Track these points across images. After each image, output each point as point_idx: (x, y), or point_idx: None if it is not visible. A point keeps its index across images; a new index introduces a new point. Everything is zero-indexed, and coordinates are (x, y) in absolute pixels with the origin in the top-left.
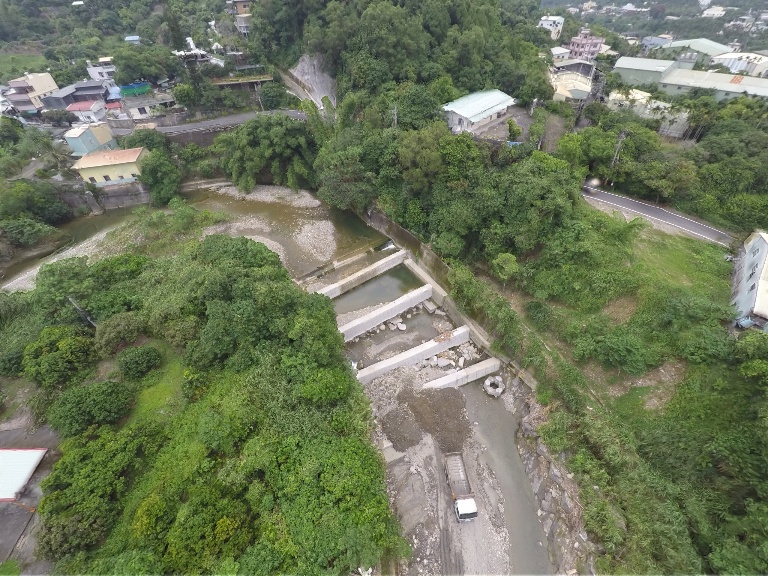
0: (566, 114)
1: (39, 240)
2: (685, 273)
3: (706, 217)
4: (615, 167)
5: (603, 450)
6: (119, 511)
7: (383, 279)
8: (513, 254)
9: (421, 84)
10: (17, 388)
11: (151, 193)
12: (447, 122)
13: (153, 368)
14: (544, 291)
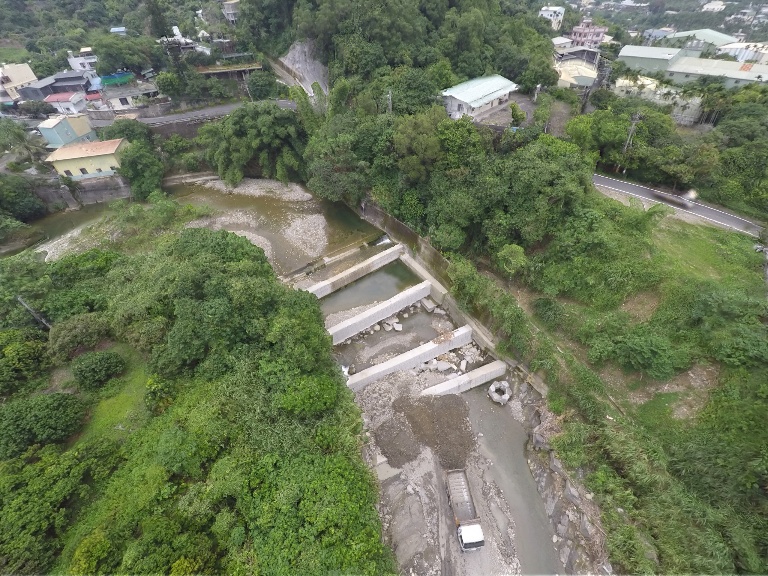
0: (572, 100)
1: (7, 237)
2: (711, 265)
3: (729, 205)
4: (628, 152)
5: (627, 467)
6: (56, 551)
7: (378, 276)
8: None
9: None
10: None
11: (132, 187)
12: (445, 108)
13: (114, 376)
14: (554, 286)
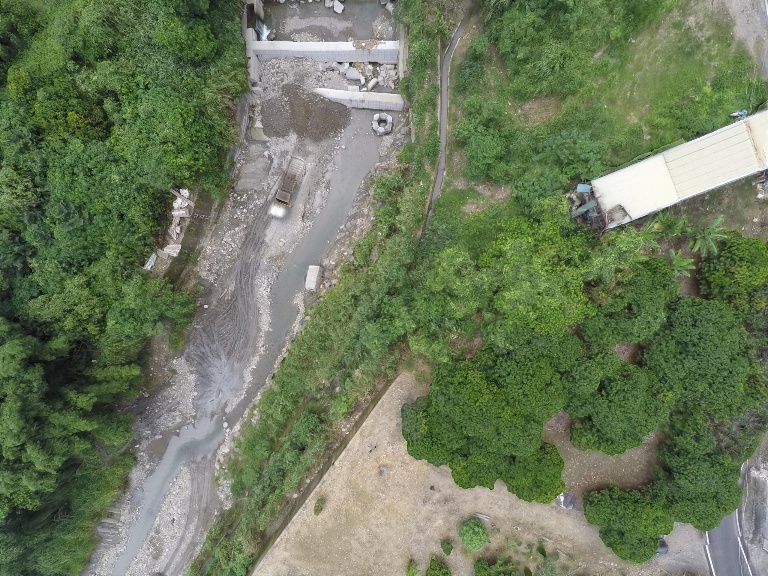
0: None
1: None
2: (652, 103)
3: None
4: None
5: None
6: (4, 70)
7: None
8: None
9: None
10: None
11: None
12: None
13: None
14: (486, 39)
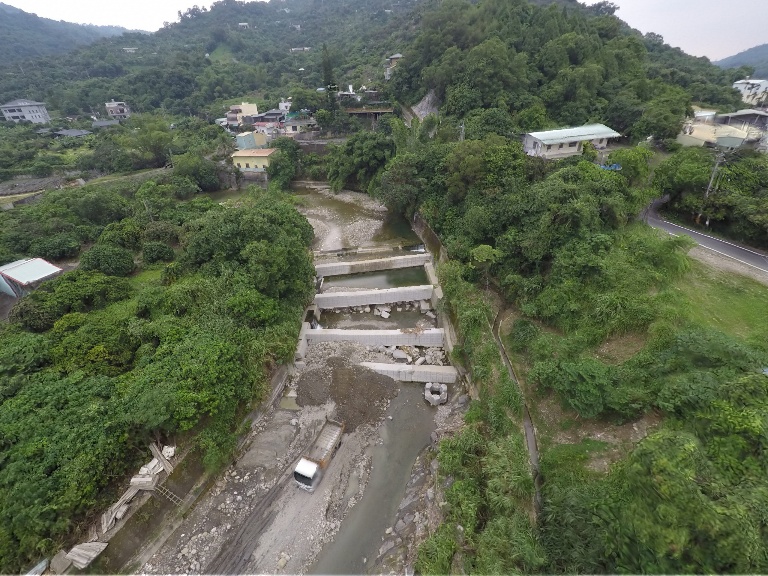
0: None
1: (189, 194)
2: (750, 325)
3: None
4: (709, 198)
5: None
6: None
7: (396, 274)
8: (532, 273)
9: (512, 113)
10: None
11: (271, 182)
12: None
13: (162, 259)
14: (533, 306)
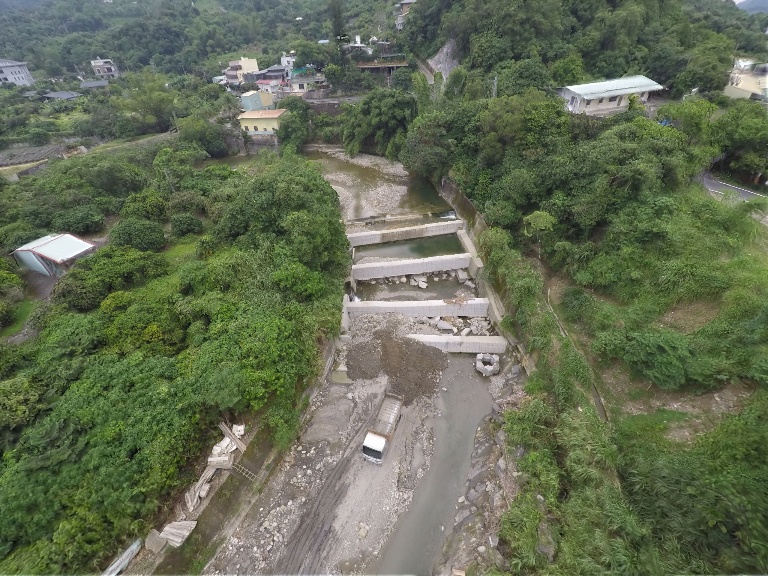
0: (737, 107)
1: (197, 161)
2: None
3: None
4: None
5: (569, 457)
6: None
7: (428, 242)
8: (578, 239)
9: None
10: (115, 221)
11: (282, 146)
12: None
13: (192, 232)
14: (589, 274)
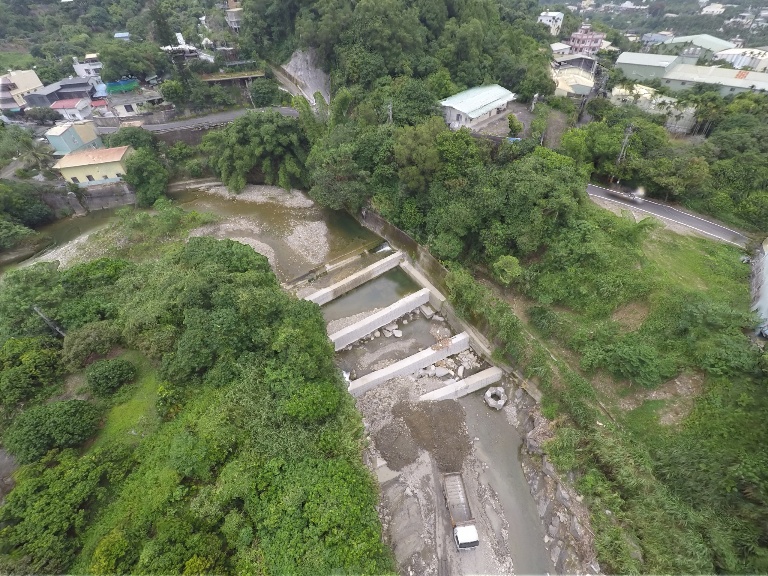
0: (568, 109)
1: (17, 243)
2: (699, 276)
3: (719, 216)
4: (622, 164)
5: (615, 471)
6: (77, 549)
7: (378, 283)
8: (515, 256)
9: None
10: None
11: (137, 193)
12: (445, 118)
13: (126, 383)
14: (548, 296)
